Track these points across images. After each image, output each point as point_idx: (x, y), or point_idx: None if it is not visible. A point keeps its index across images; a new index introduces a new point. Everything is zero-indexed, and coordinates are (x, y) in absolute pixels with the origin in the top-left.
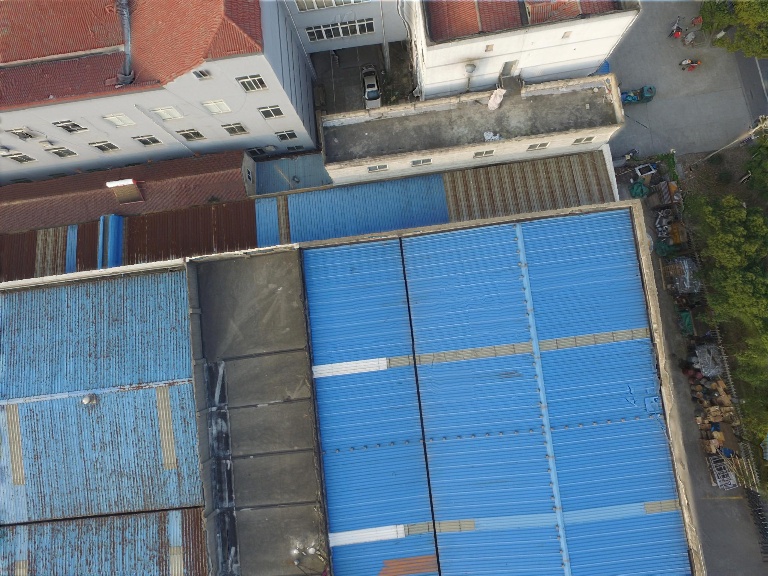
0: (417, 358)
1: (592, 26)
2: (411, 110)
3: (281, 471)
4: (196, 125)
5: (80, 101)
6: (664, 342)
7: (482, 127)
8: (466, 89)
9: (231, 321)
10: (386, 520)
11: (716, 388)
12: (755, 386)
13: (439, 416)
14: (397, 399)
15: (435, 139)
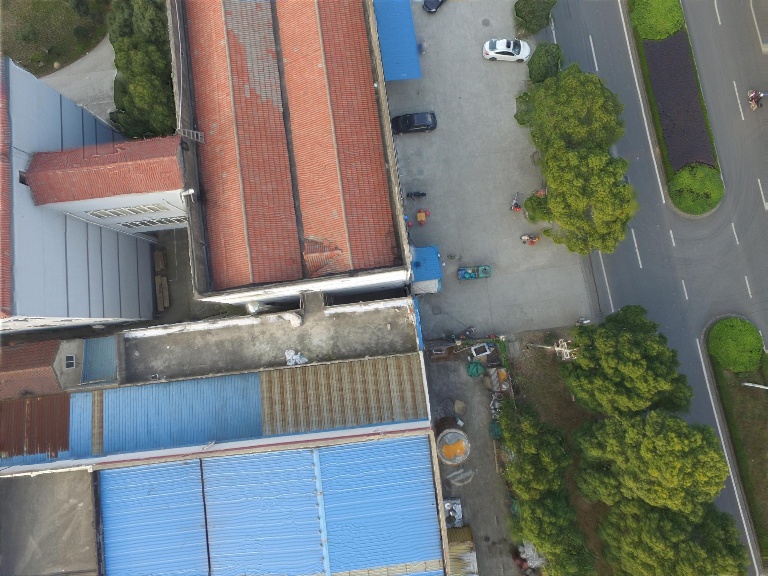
0: None
1: (366, 277)
2: (213, 324)
3: None
4: None
5: None
6: (495, 526)
7: (284, 344)
8: (273, 299)
9: (30, 537)
10: None
11: None
12: None
13: None
14: None
15: (237, 356)
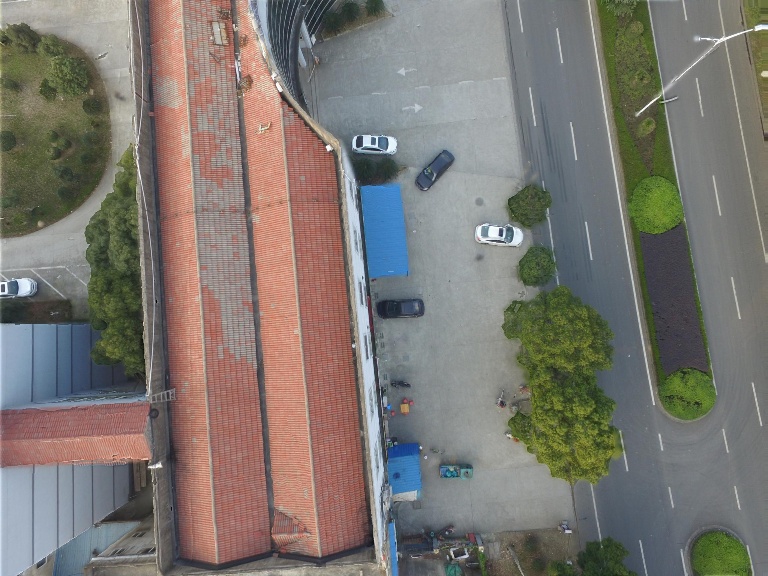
0: None
1: None
2: None
3: None
4: None
5: None
6: None
7: None
8: None
9: None
10: None
11: None
12: None
13: None
14: None
15: None
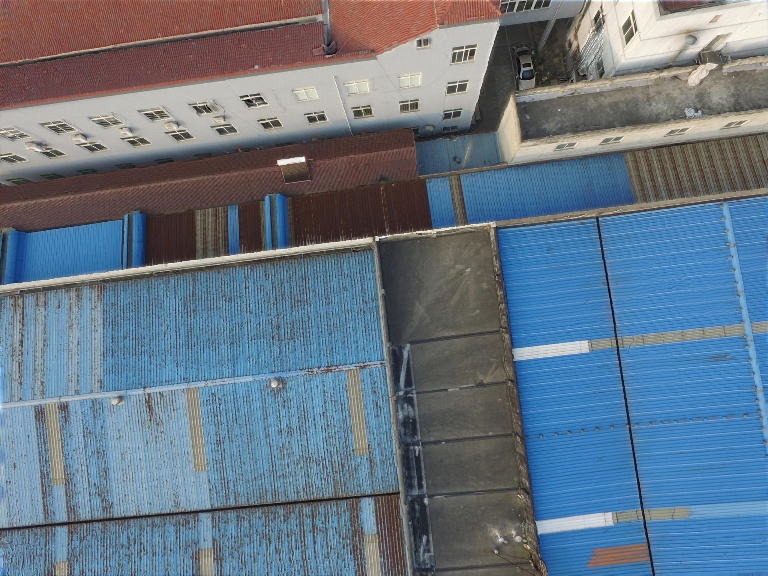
0: (620, 341)
1: None
2: (606, 86)
3: (475, 457)
4: (375, 101)
5: (284, 72)
6: None
7: (682, 103)
8: (660, 65)
9: (417, 303)
10: (594, 507)
11: None
12: None
13: (643, 401)
14: (596, 383)
15: (633, 116)
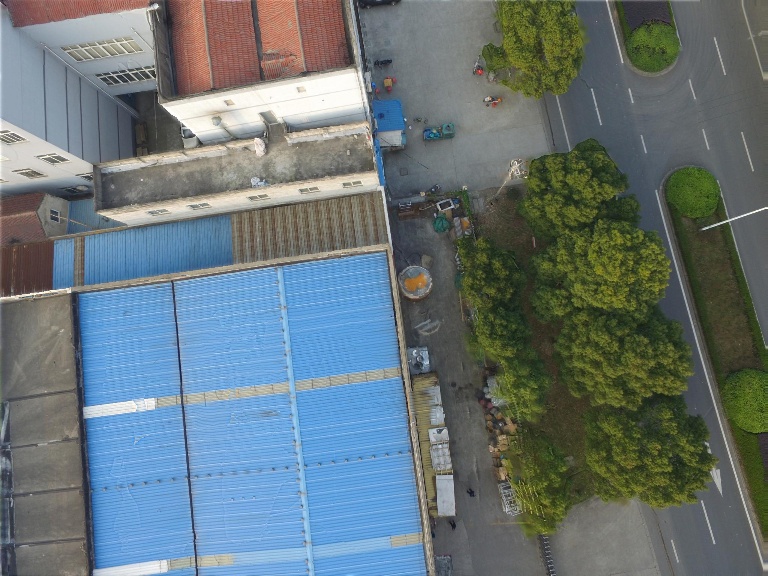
0: (184, 398)
1: (320, 82)
2: (184, 157)
3: (58, 508)
4: None
5: None
6: (462, 372)
7: (250, 173)
8: (240, 135)
9: (15, 362)
10: (149, 556)
11: (502, 418)
12: (542, 415)
13: (206, 454)
14: (168, 437)
15: (206, 185)
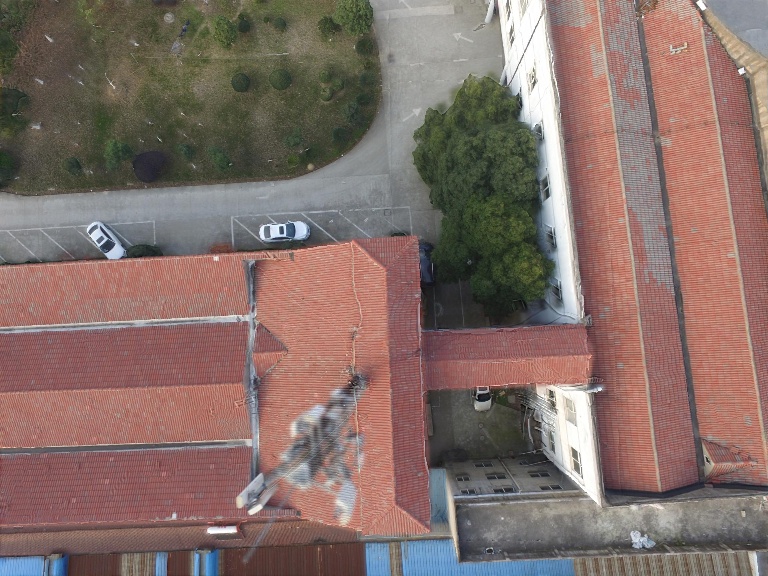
0: None
1: None
2: None
3: None
4: None
5: None
6: None
7: (629, 524)
8: None
9: None
10: None
11: None
12: None
13: None
14: None
15: (577, 533)
